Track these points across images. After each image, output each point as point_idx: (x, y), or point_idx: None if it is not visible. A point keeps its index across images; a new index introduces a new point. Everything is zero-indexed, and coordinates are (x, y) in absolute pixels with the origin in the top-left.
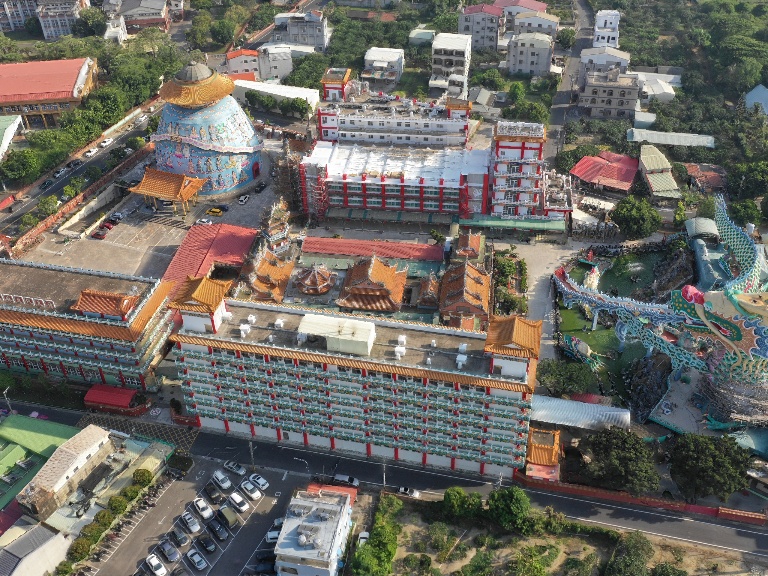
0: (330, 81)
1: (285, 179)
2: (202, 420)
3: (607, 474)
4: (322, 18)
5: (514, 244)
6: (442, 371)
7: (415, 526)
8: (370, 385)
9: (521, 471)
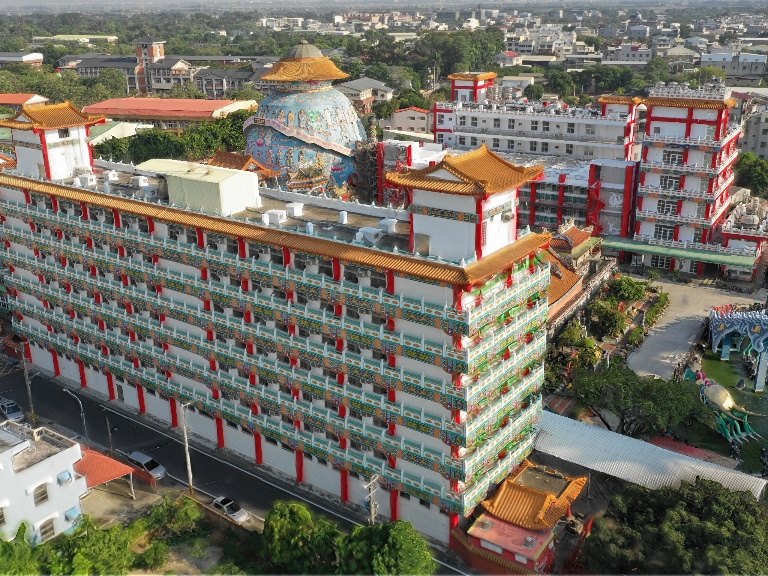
0: (460, 77)
1: (363, 170)
2: (33, 351)
3: (646, 562)
4: (520, 96)
5: (662, 282)
6: (315, 236)
7: (196, 567)
8: (212, 274)
9: (466, 529)
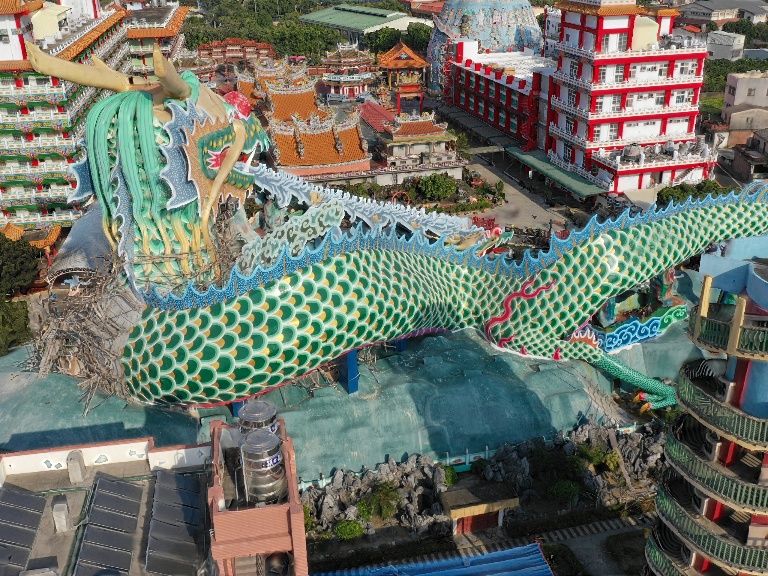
0: None
1: None
2: None
3: None
4: None
5: (531, 200)
6: None
7: None
8: None
9: None
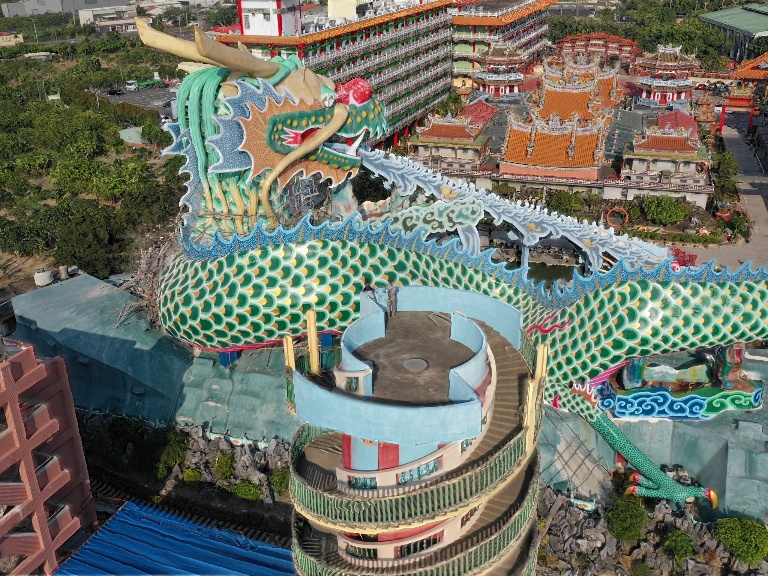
0: None
1: None
2: None
3: None
4: None
5: None
6: None
7: None
8: None
9: None
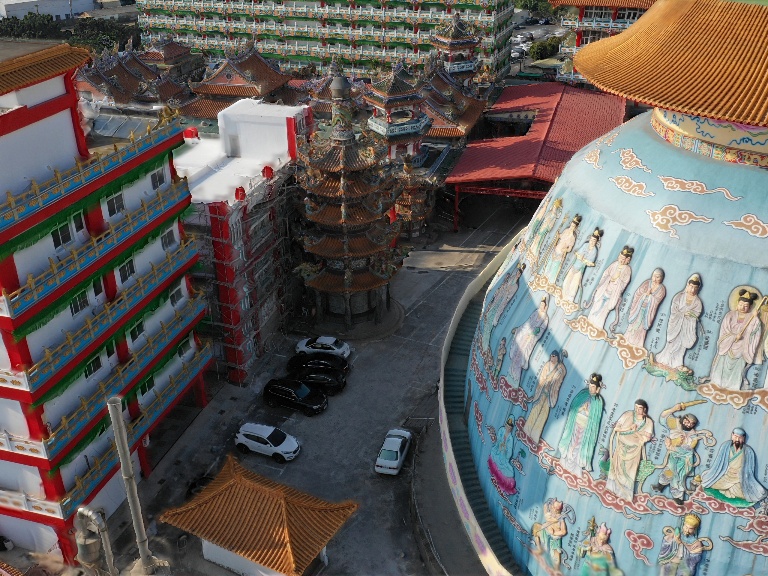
0: None
1: None
2: None
3: None
4: None
5: None
6: None
7: None
8: None
9: None
